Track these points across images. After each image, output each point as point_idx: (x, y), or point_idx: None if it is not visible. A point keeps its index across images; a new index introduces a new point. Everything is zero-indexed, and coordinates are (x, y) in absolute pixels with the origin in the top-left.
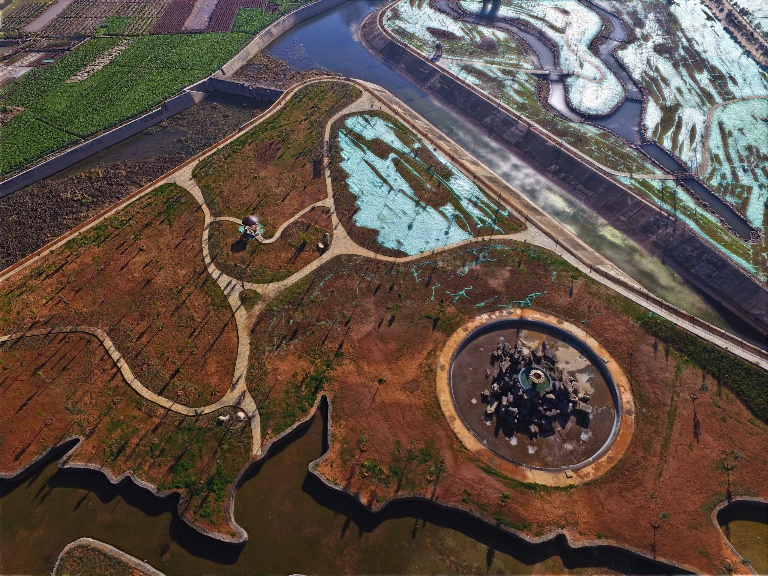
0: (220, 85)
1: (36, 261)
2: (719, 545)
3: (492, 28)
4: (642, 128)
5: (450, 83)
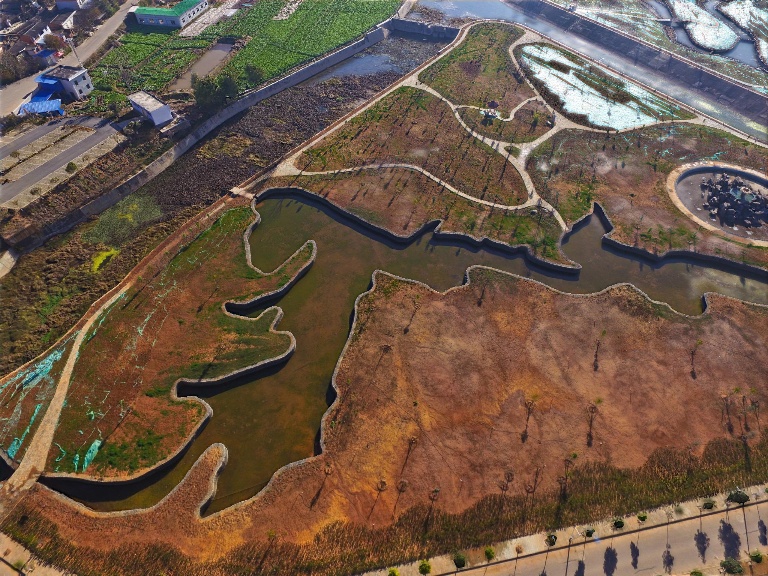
0: (400, 25)
1: (336, 130)
2: None
3: None
4: (761, 59)
5: (592, 26)
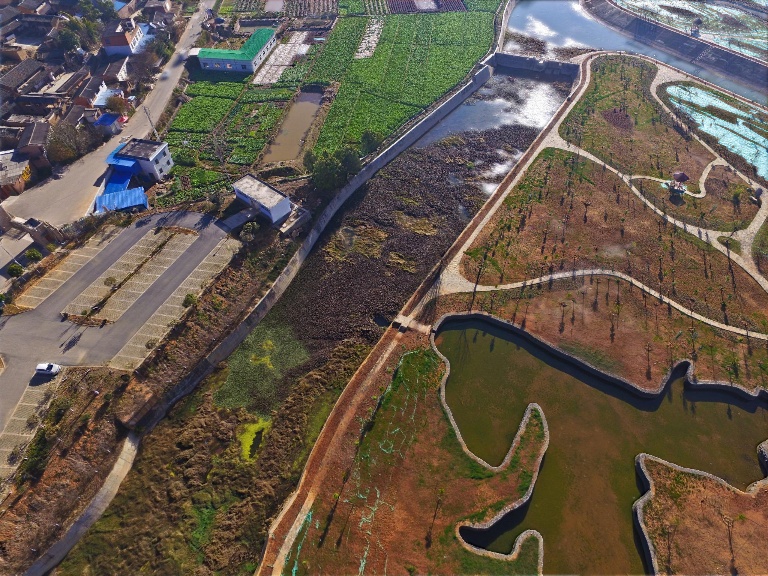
0: (505, 60)
1: (493, 216)
2: None
3: (718, 6)
4: None
5: (727, 56)
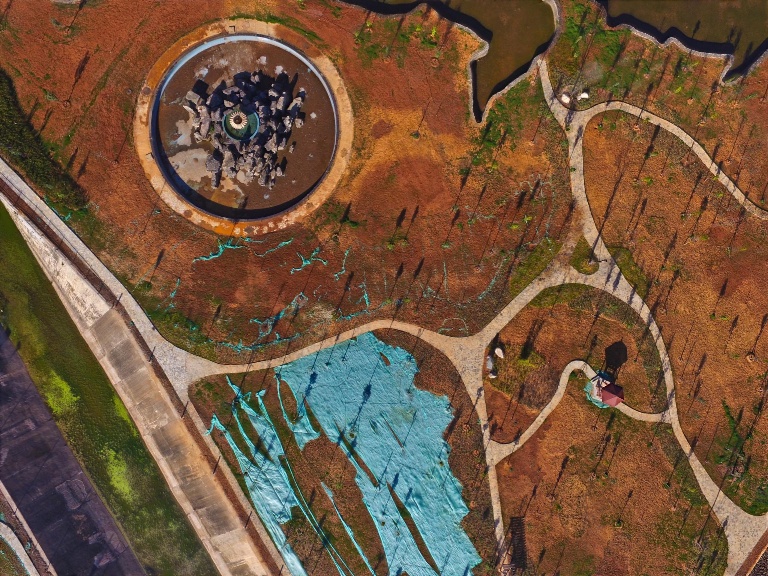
0: None
1: None
2: None
3: None
4: None
5: None
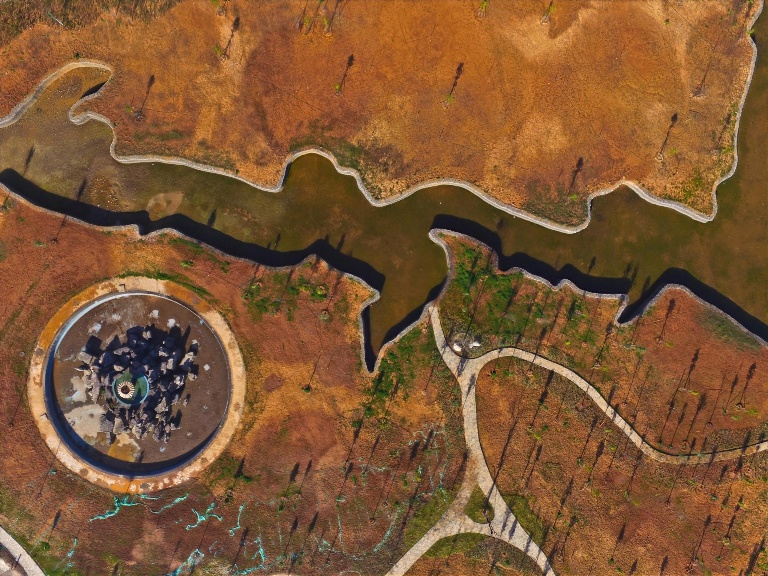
0: None
1: None
2: (3, 226)
3: None
4: None
5: None
